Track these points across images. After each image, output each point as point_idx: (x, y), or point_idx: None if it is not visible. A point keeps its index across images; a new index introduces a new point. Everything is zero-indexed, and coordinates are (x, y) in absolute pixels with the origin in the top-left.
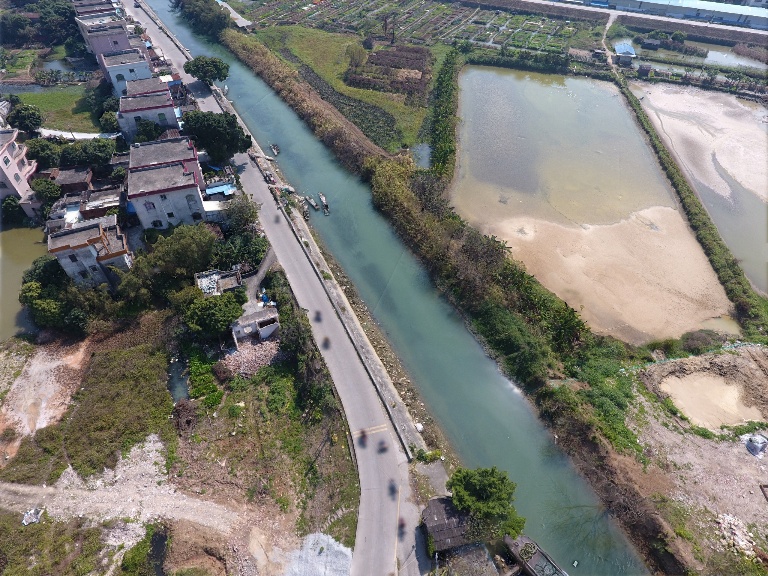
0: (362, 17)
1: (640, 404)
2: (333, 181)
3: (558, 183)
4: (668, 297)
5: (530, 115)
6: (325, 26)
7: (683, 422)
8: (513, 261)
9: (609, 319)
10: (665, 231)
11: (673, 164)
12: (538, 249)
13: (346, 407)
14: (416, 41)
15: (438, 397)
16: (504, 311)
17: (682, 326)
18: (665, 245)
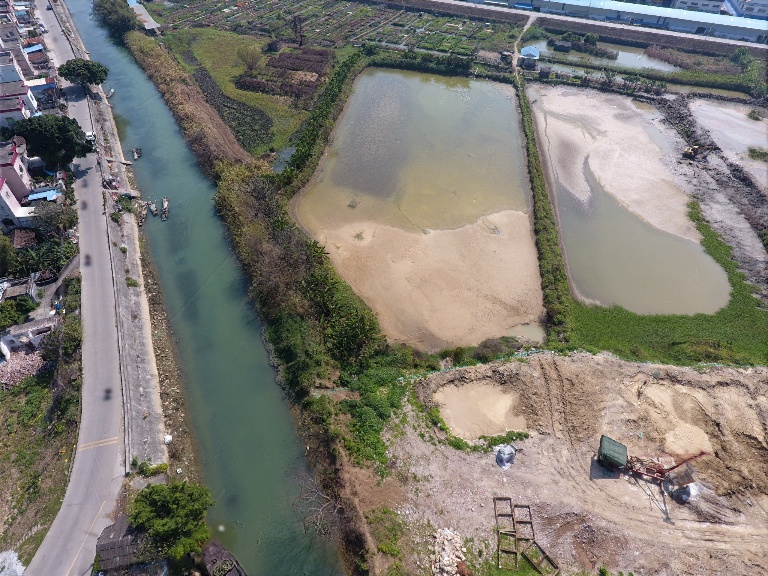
0: (280, 19)
1: (404, 414)
2: (184, 186)
3: (416, 187)
4: (482, 303)
5: (415, 118)
6: (237, 28)
7: (441, 432)
8: (325, 267)
9: (413, 326)
10: (506, 236)
11: (538, 167)
12: (369, 254)
13: (84, 419)
14: (325, 43)
15: (204, 407)
16: (294, 319)
17: (485, 333)
18: (501, 250)
